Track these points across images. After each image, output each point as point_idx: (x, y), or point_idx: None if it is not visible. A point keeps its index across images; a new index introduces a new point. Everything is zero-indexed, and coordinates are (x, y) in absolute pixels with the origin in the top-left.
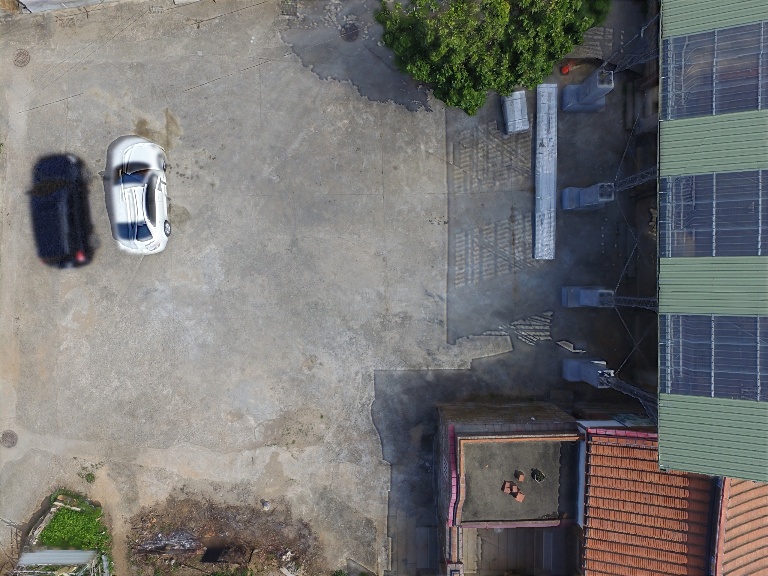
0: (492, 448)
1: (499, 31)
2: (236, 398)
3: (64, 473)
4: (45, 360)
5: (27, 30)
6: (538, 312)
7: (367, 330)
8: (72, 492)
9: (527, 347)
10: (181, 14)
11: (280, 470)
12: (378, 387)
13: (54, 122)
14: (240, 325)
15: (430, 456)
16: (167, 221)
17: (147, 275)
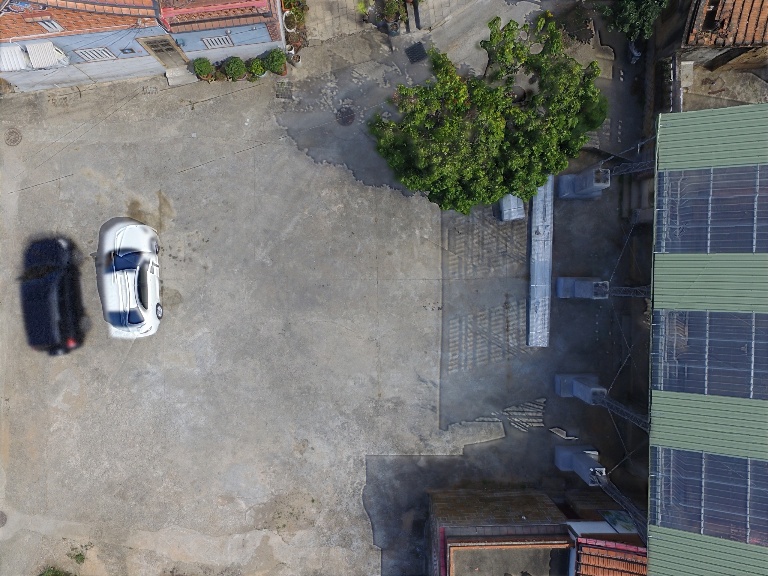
0: (482, 551)
1: None
2: (227, 481)
3: (53, 553)
4: (35, 442)
5: (19, 109)
6: (531, 399)
7: (359, 415)
8: (61, 573)
9: (520, 433)
10: (175, 95)
11: (270, 554)
12: (370, 472)
13: (46, 203)
14: (232, 409)
15: (421, 541)
16: (159, 304)
17: (138, 358)
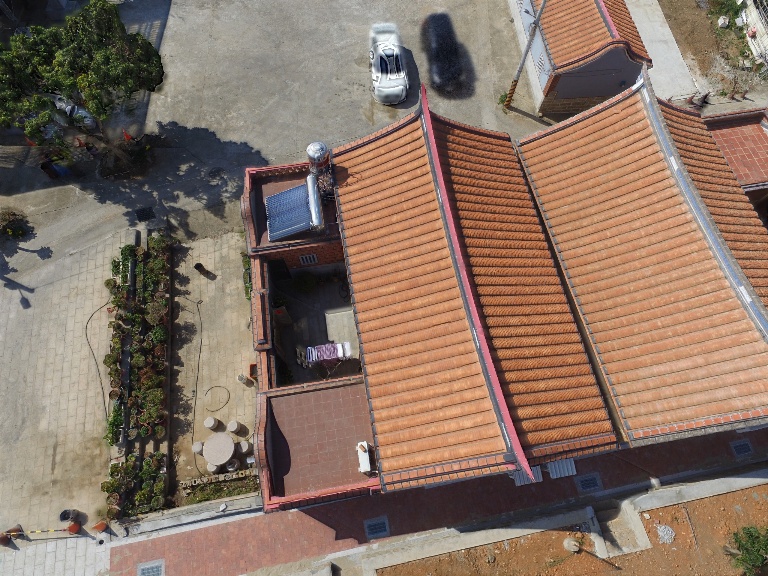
0: None
1: None
2: None
3: None
4: None
5: None
6: None
7: (230, 1)
8: None
9: None
10: None
11: None
12: None
13: (461, 118)
14: (320, 5)
15: None
16: (372, 59)
17: (386, 31)
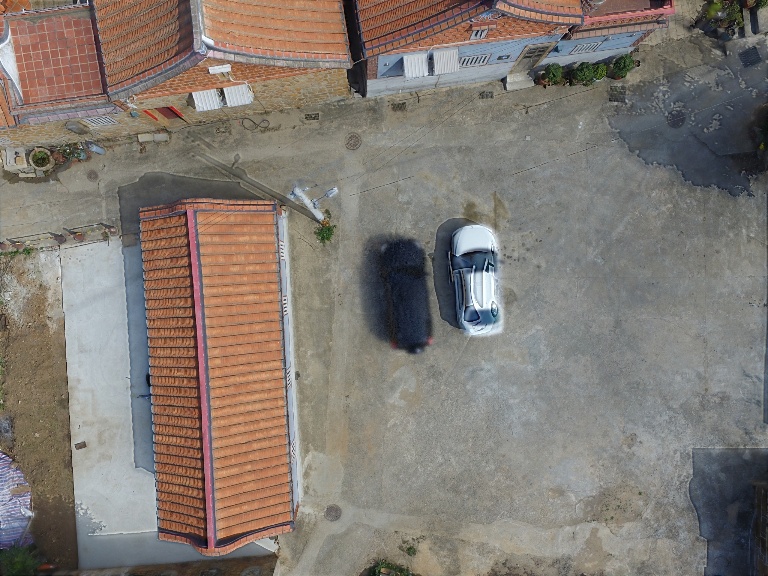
0: None
1: None
2: (557, 475)
3: (385, 546)
4: (373, 437)
5: (359, 114)
6: None
7: (686, 409)
8: (393, 565)
9: None
10: (510, 99)
11: (599, 545)
12: (696, 465)
13: (385, 204)
14: (563, 404)
15: (746, 533)
16: (494, 302)
17: (473, 355)
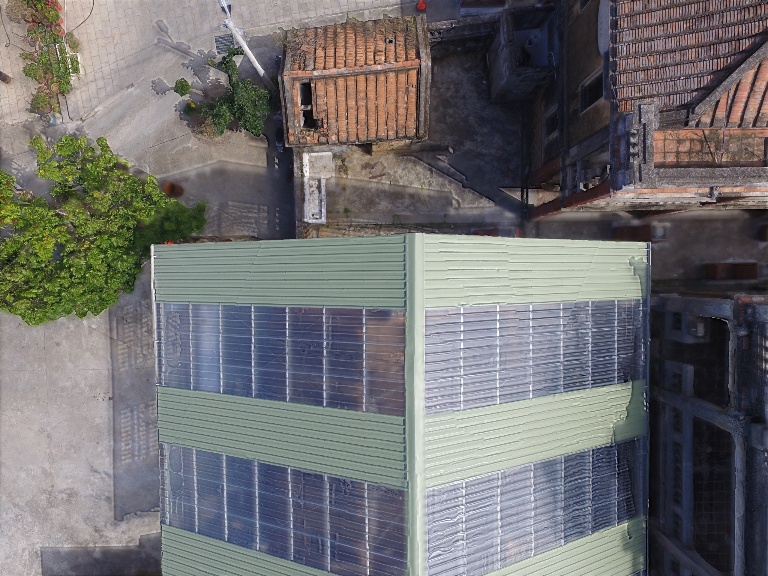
0: None
1: (27, 274)
2: None
3: None
4: None
5: None
6: None
7: (33, 507)
8: None
9: None
10: None
11: None
12: (45, 564)
13: None
14: None
15: None
16: None
17: None
